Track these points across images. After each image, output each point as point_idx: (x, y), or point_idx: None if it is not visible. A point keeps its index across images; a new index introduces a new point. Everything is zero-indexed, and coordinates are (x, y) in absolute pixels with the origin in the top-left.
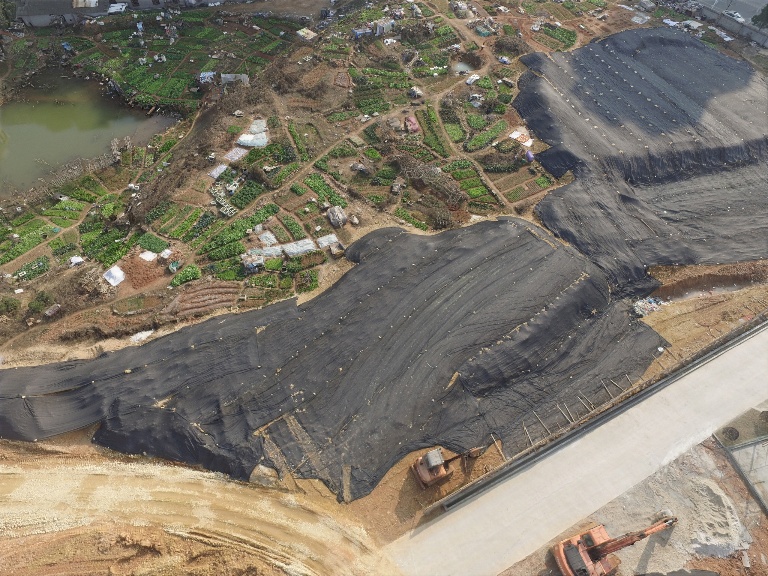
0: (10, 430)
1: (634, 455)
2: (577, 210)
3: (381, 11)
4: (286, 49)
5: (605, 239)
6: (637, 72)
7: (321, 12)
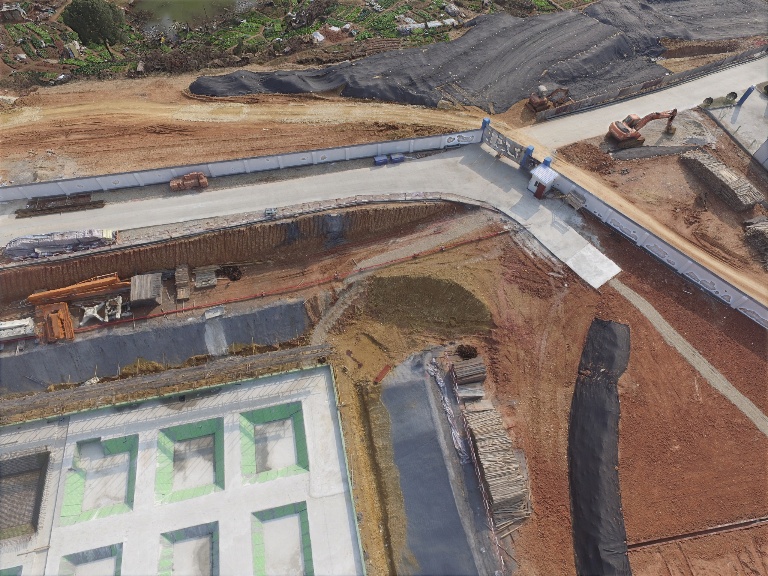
0: (295, 88)
1: (651, 111)
2: (612, 10)
3: None
4: None
5: (631, 24)
6: None
7: None
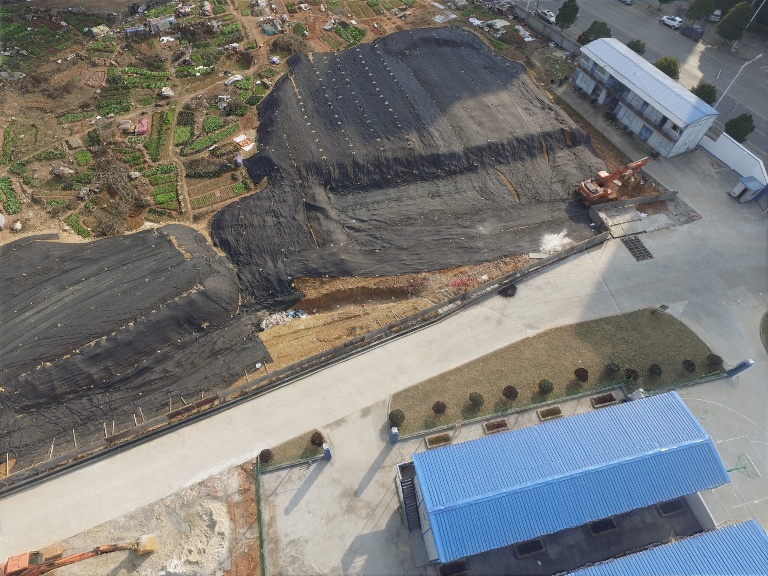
0: None
1: (158, 476)
2: (248, 218)
3: (174, 8)
4: None
5: (261, 249)
6: (393, 74)
7: None
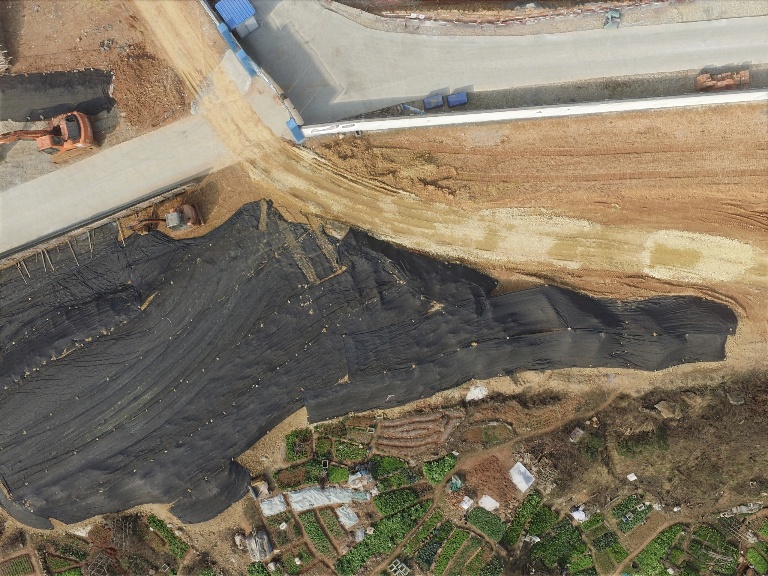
0: (573, 298)
1: None
2: None
3: None
4: None
5: None
6: None
7: None
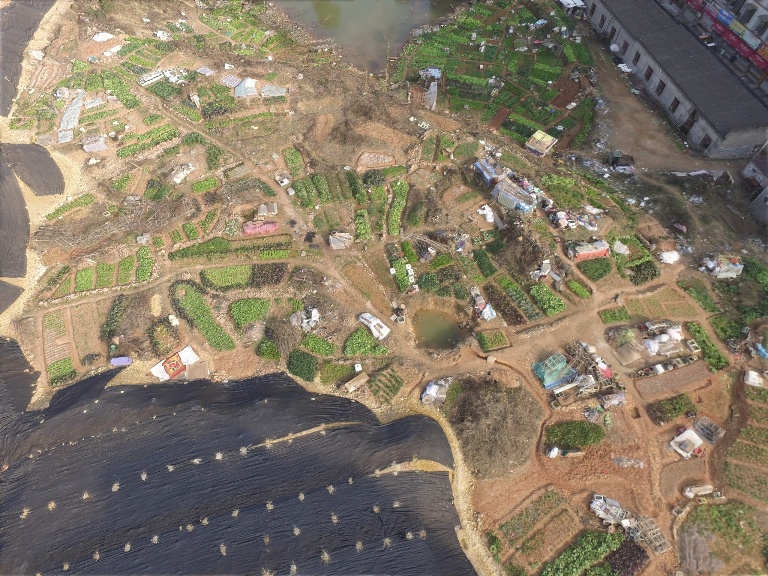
0: None
1: None
2: None
3: (588, 204)
4: (518, 134)
5: None
6: None
7: (611, 153)
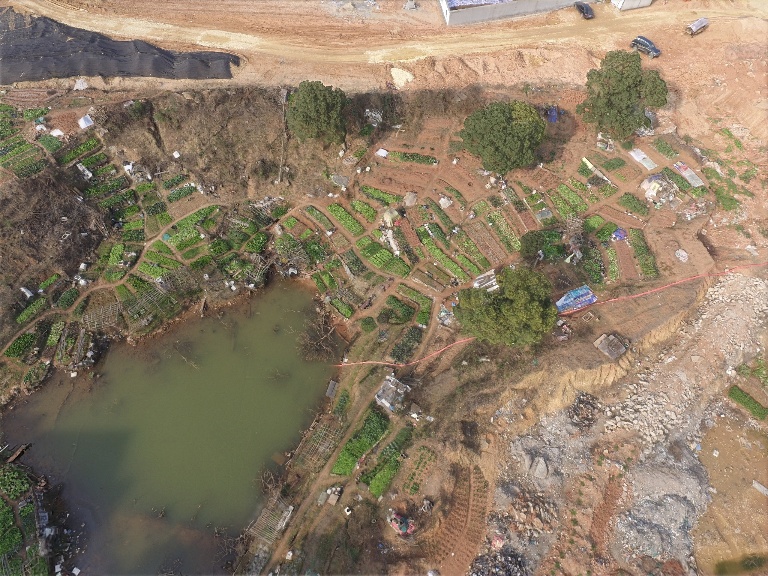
0: (148, 44)
1: None
2: None
3: None
4: None
5: None
6: None
7: None
